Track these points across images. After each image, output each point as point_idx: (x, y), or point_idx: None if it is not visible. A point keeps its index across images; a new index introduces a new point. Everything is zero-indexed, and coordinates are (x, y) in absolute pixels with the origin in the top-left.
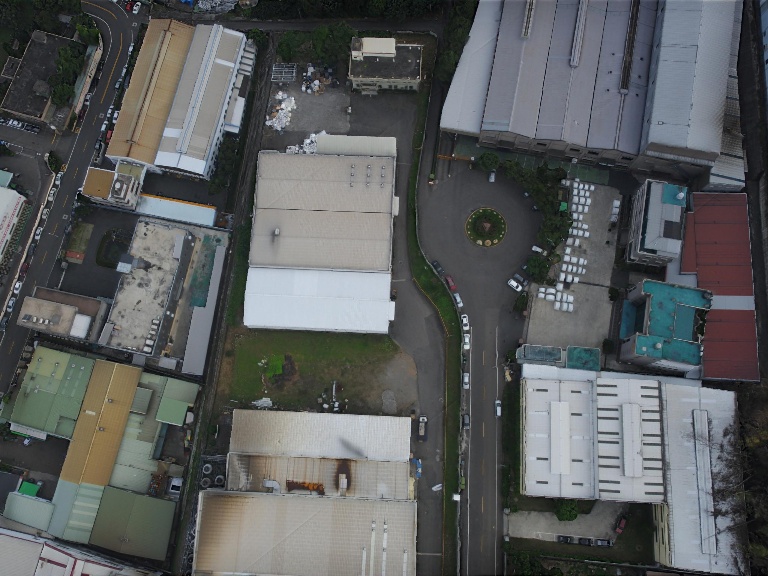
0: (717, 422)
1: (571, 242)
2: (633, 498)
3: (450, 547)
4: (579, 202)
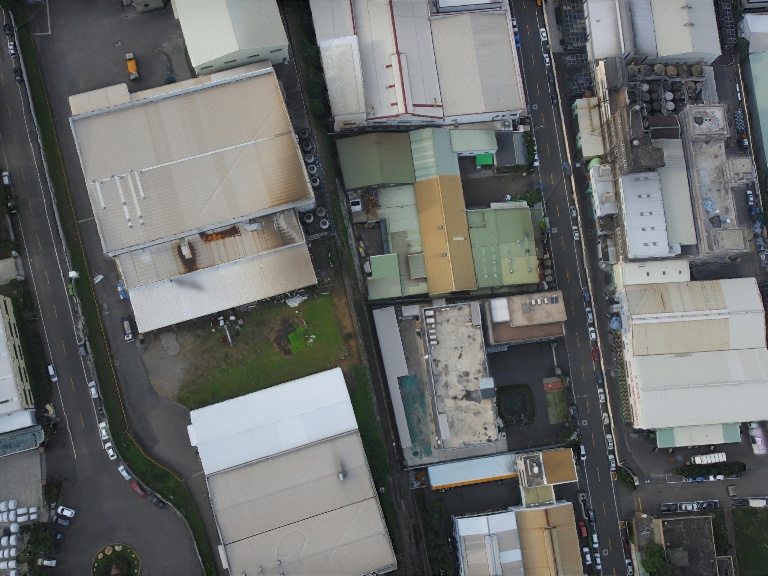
0: None
1: None
2: None
3: (70, 230)
4: None
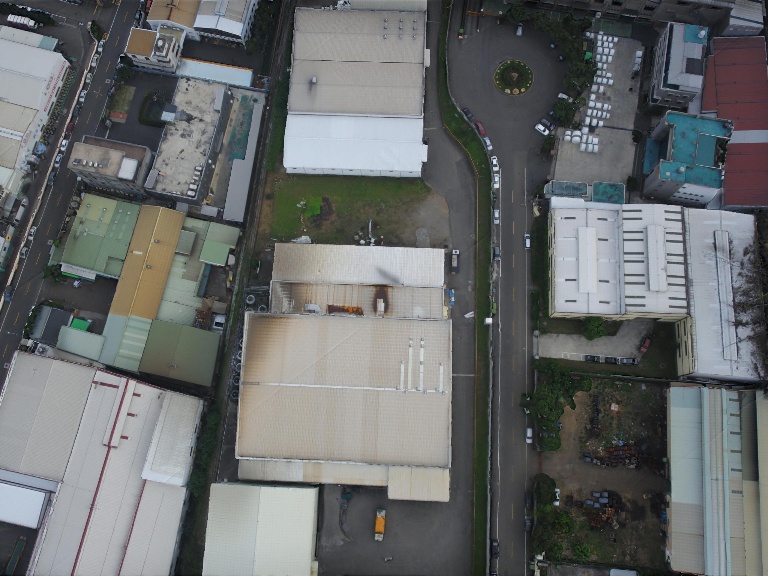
0: (737, 242)
1: (596, 89)
2: (658, 311)
3: (483, 367)
4: (603, 52)
